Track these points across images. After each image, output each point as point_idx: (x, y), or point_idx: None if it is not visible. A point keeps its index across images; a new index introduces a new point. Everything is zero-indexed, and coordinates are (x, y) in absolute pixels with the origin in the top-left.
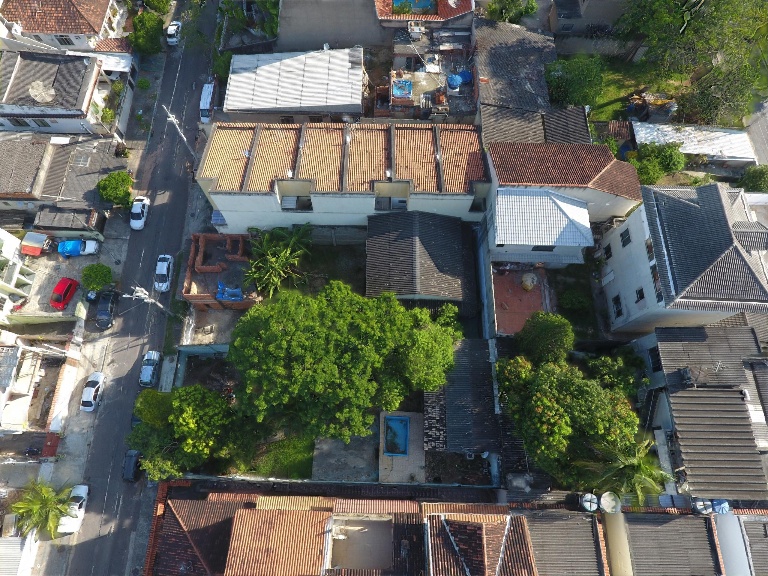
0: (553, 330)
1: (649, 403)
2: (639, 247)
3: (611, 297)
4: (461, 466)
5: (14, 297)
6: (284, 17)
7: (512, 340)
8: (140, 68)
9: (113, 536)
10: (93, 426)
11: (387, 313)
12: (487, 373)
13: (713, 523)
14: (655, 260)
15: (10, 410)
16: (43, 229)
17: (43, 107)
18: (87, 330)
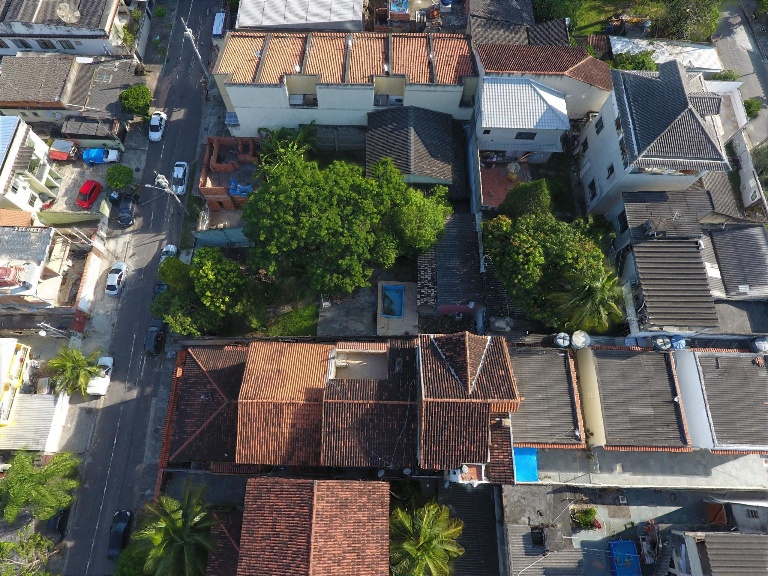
0: (531, 189)
1: (618, 263)
2: (610, 128)
3: (587, 184)
4: (450, 326)
5: (44, 196)
6: None
7: (496, 212)
8: (156, 1)
9: (136, 401)
10: (117, 309)
11: (384, 174)
12: (474, 241)
13: (672, 359)
14: (622, 129)
15: (43, 288)
16: (69, 138)
17: (69, 27)
18: (110, 228)
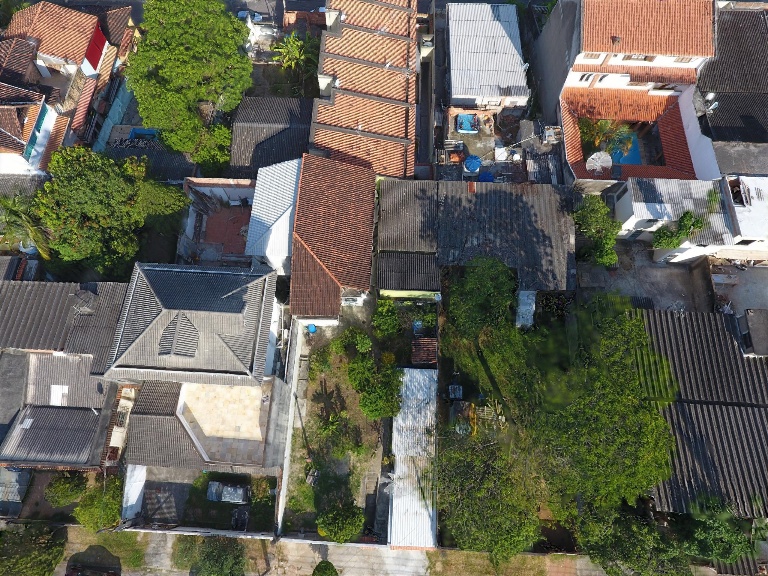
0: None
1: None
2: None
3: None
4: None
5: None
6: (550, 21)
7: None
8: None
9: None
10: None
11: None
12: None
13: None
14: None
15: None
16: None
17: None
18: None
